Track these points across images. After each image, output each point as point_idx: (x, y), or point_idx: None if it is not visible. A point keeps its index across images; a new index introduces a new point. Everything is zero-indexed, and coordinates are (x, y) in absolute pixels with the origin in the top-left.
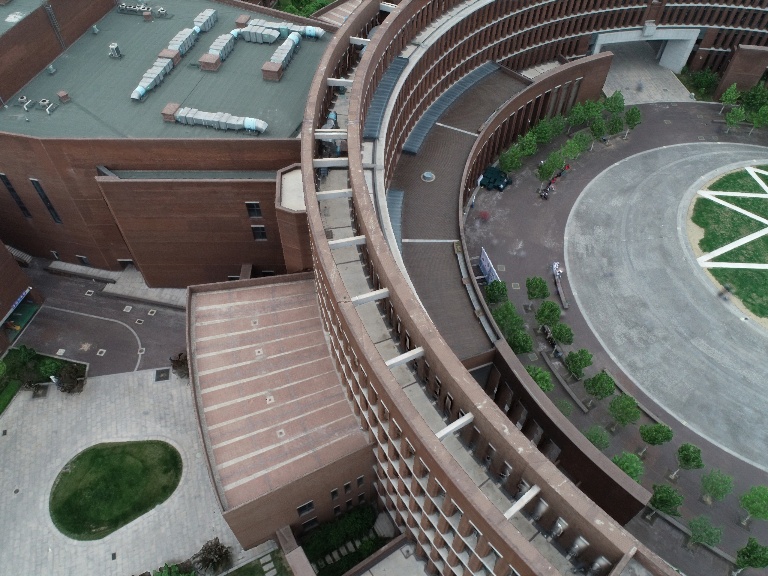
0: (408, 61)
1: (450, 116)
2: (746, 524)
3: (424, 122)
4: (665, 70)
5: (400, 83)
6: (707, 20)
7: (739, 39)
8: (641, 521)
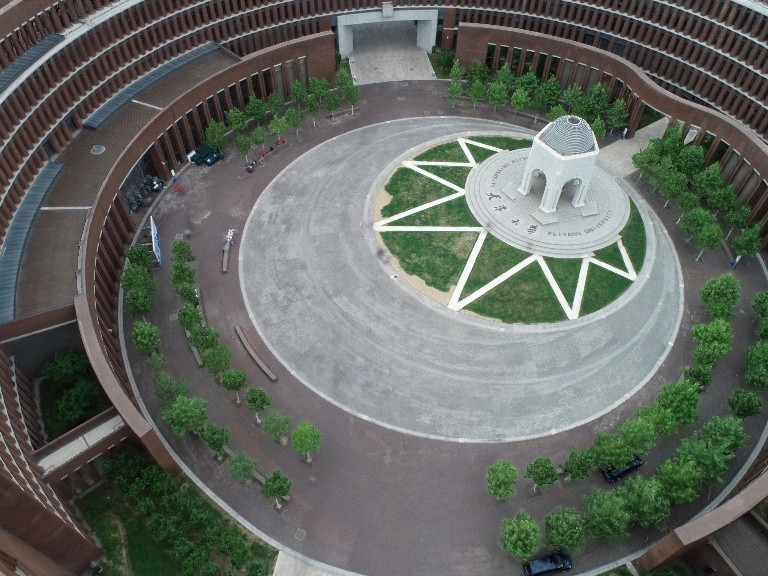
0: (64, 37)
1: (149, 93)
2: (311, 461)
3: (117, 99)
4: (420, 51)
5: (44, 58)
6: (442, 1)
7: (476, 18)
8: (211, 462)
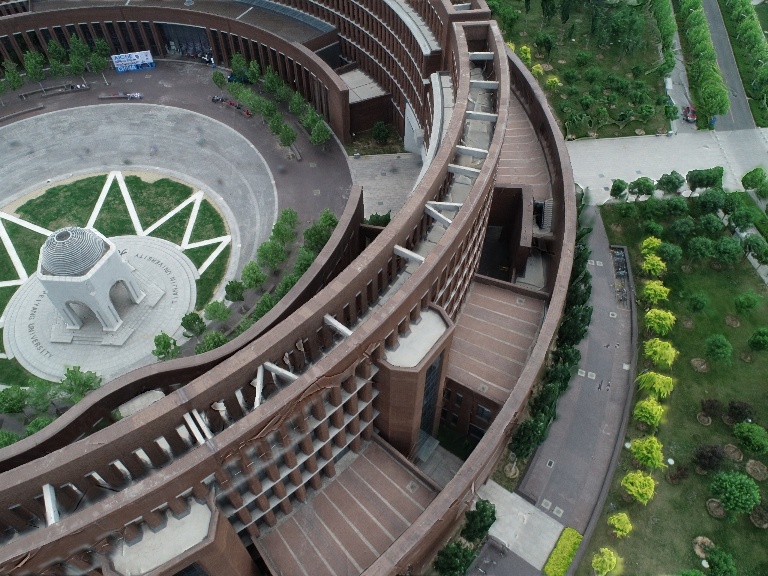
0: None
1: (260, 13)
2: None
3: None
4: None
5: None
6: None
7: None
8: None
